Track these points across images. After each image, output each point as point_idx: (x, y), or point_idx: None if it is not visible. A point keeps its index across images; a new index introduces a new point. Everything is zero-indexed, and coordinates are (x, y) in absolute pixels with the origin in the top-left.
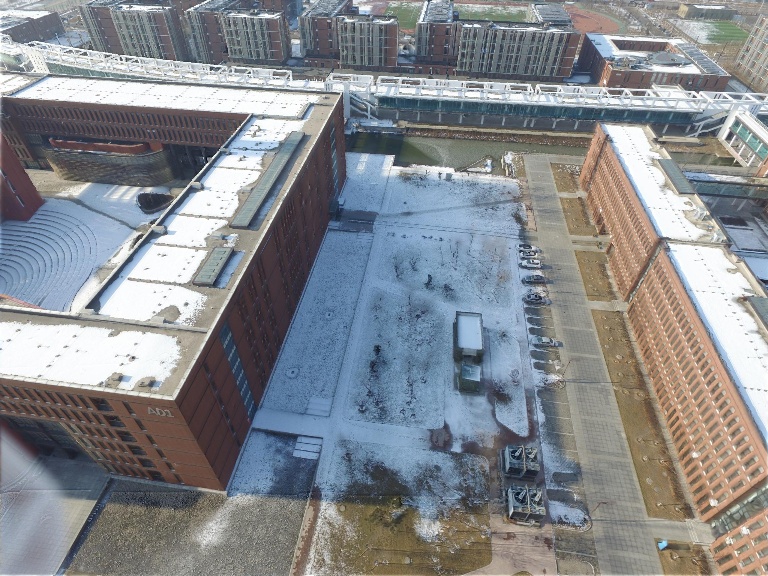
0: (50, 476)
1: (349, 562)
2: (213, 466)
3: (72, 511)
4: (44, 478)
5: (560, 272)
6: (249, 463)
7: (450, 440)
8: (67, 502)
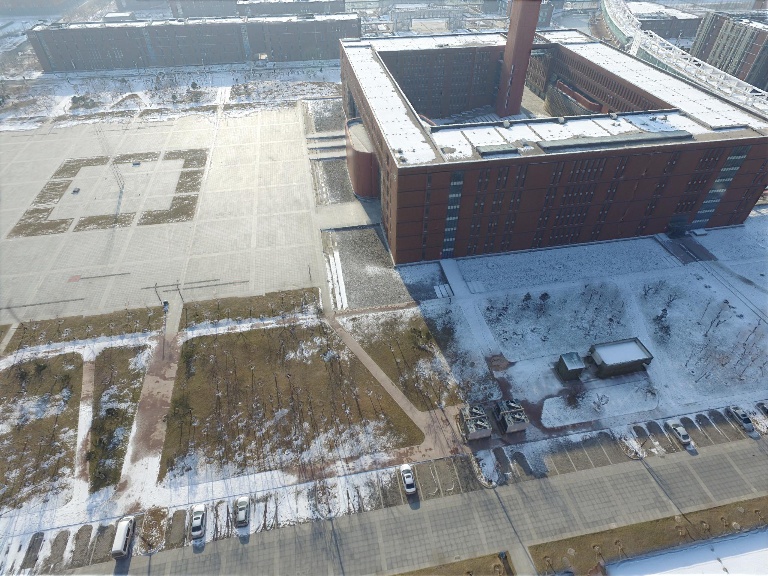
0: (370, 205)
1: (384, 331)
2: (398, 238)
3: (358, 219)
4: (368, 204)
5: None
6: (417, 269)
7: (502, 368)
8: (361, 216)
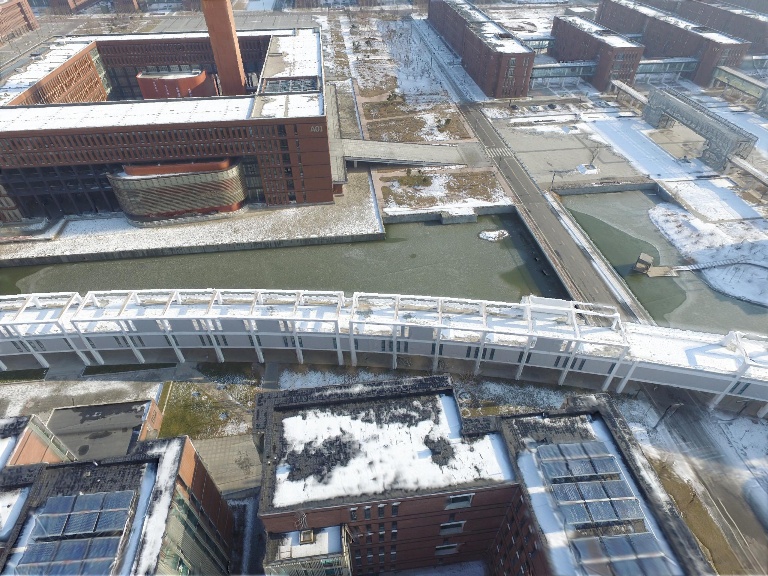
0: None
1: None
2: None
3: None
4: None
5: None
6: None
7: None
8: None
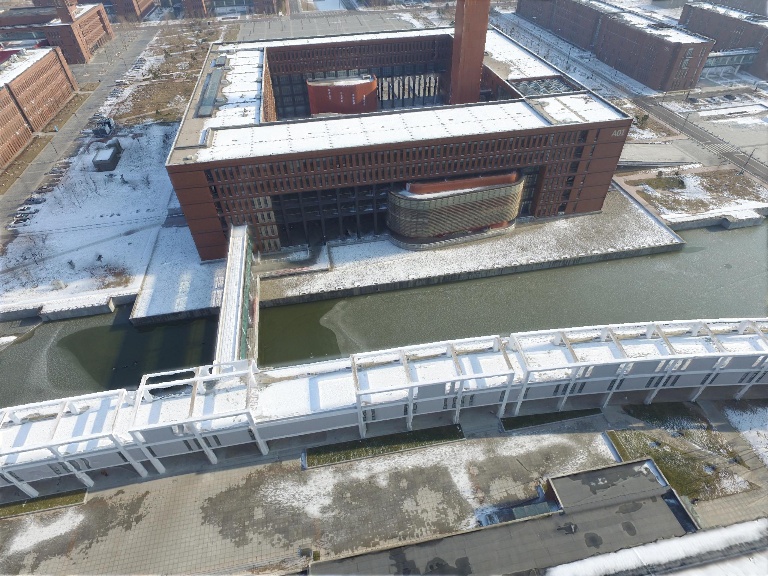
0: None
1: None
2: None
3: None
4: None
5: (4, 213)
6: None
7: None
8: None
